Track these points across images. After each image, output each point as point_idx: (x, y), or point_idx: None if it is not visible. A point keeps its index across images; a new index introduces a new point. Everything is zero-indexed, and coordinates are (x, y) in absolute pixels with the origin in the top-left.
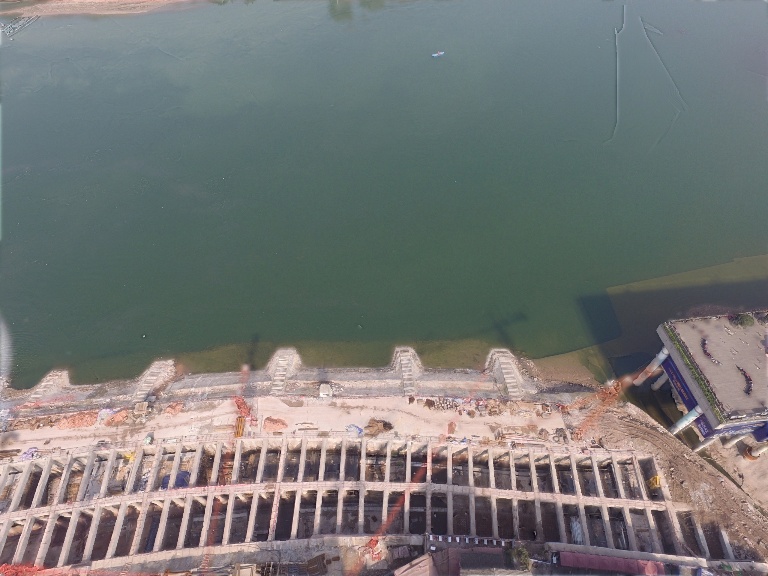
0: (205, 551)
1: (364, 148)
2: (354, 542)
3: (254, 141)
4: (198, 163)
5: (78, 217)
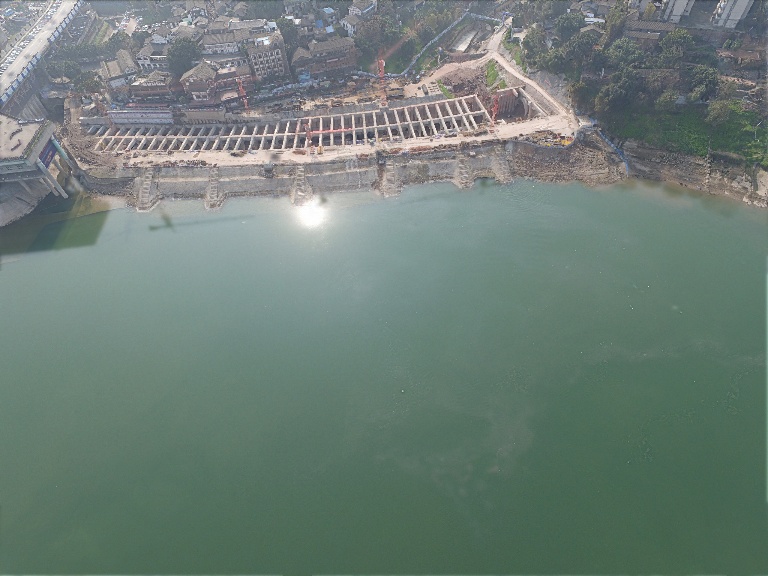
0: (329, 116)
1: (180, 486)
2: (258, 115)
3: (376, 496)
4: (457, 431)
5: (568, 322)
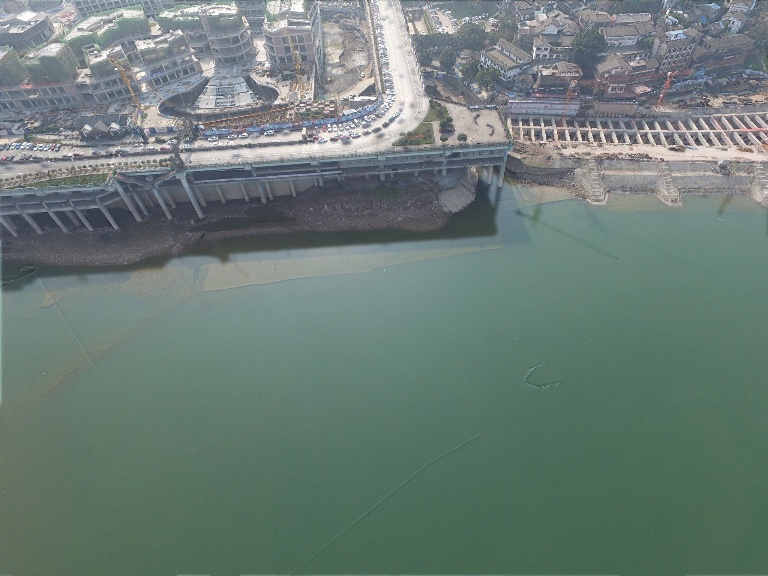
0: None
1: None
2: (670, 110)
3: None
4: None
5: None
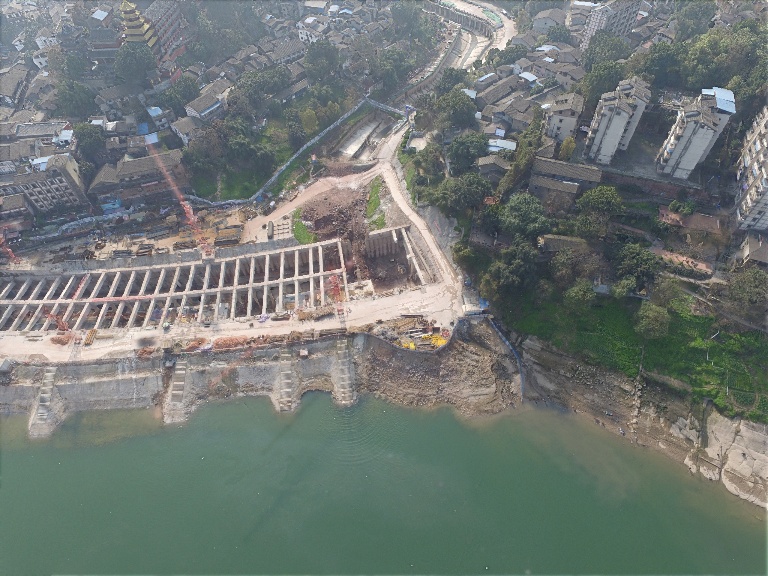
0: (131, 269)
1: None
2: (29, 267)
3: None
4: None
5: None
